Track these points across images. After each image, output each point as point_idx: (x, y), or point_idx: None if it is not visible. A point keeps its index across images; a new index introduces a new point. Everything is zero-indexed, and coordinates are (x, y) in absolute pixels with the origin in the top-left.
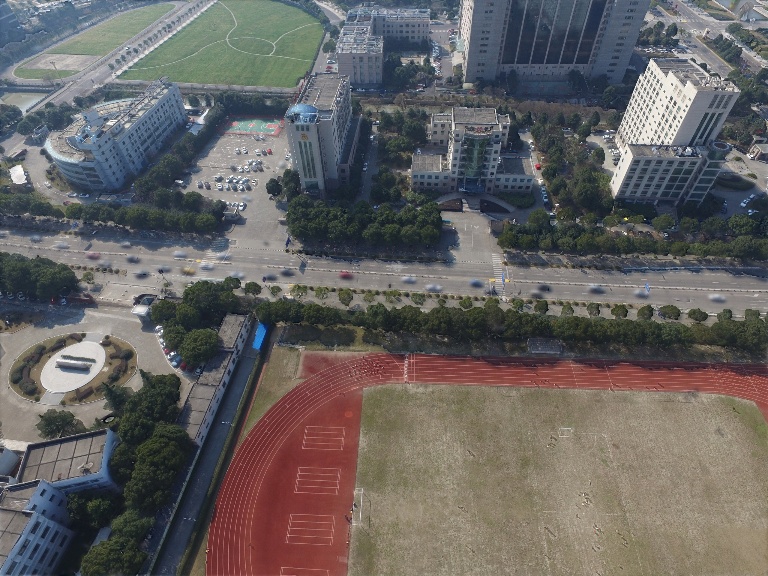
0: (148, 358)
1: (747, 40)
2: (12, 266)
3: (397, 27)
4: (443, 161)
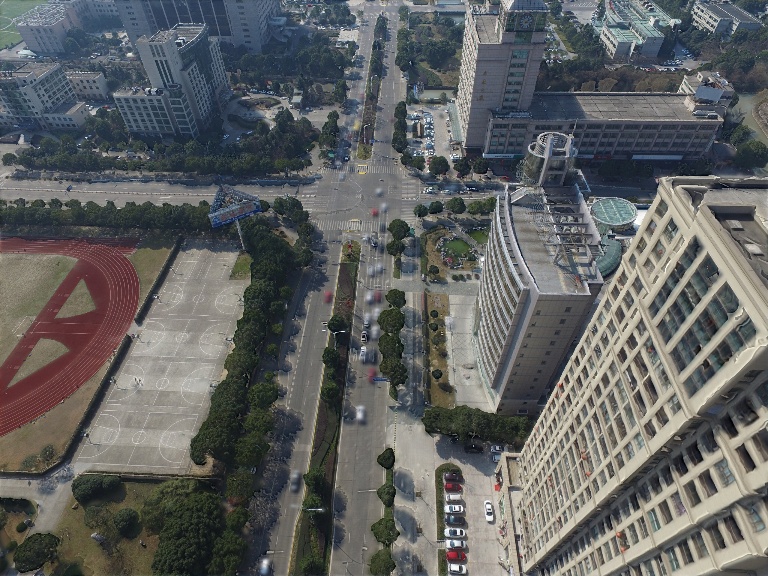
0: None
1: (403, 19)
2: None
3: (106, 7)
4: None
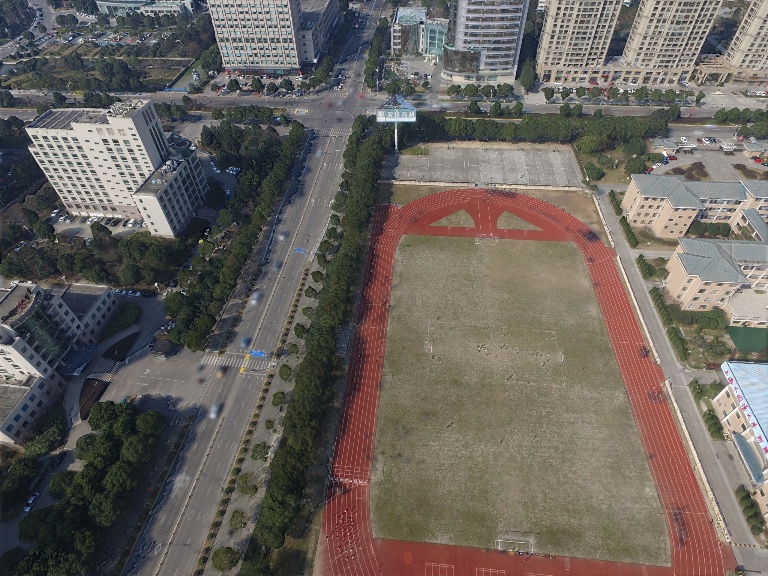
0: None
1: None
2: None
3: None
4: None
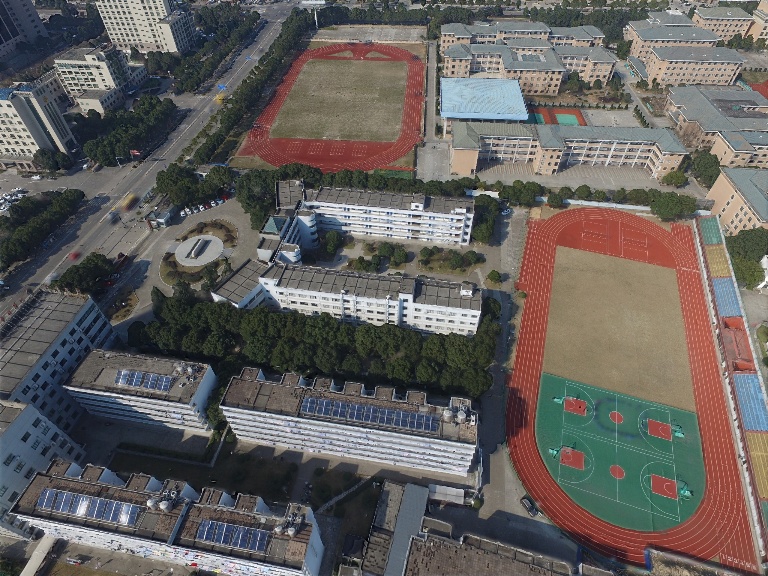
0: (210, 216)
1: None
2: (69, 274)
3: None
4: (78, 106)
